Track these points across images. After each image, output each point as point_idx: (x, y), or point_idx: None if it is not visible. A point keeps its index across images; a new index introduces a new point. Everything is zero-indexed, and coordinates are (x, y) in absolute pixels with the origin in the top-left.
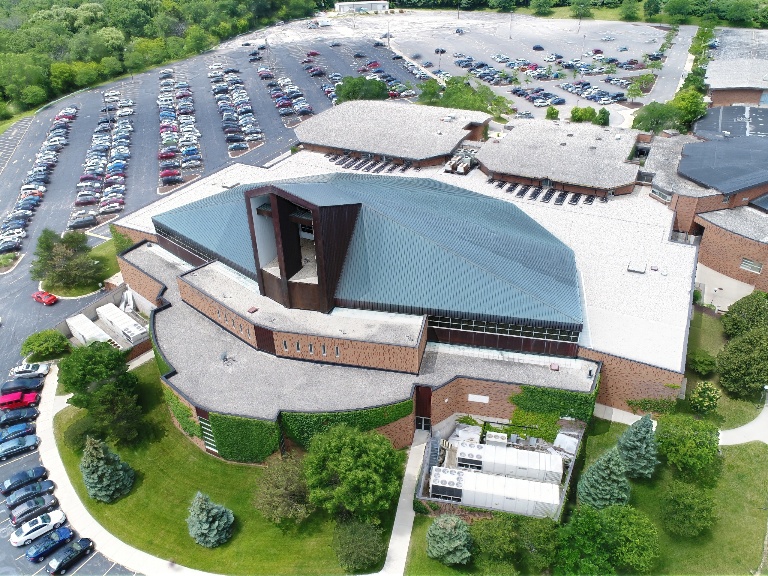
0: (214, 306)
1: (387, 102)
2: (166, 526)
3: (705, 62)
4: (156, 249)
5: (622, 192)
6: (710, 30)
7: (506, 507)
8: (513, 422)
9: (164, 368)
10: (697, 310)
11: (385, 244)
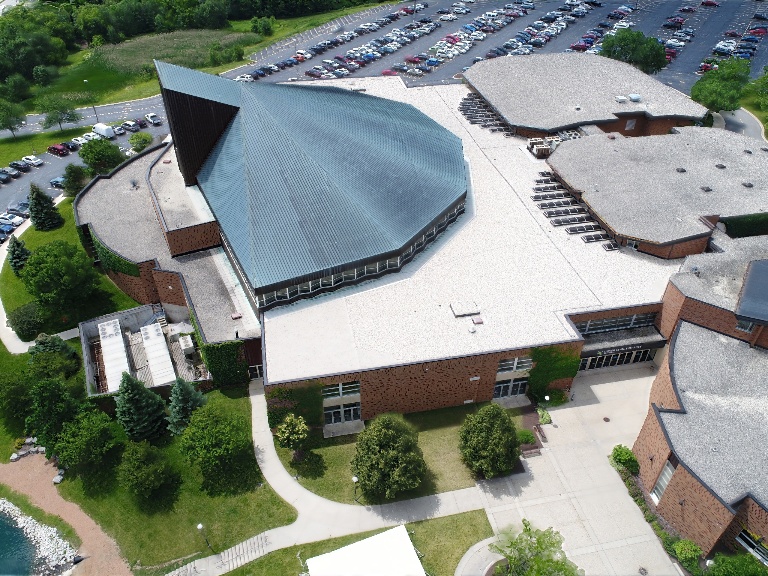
0: None
1: (625, 66)
2: None
3: None
4: None
5: (651, 251)
6: None
7: None
8: None
9: None
10: (522, 409)
11: (230, 148)
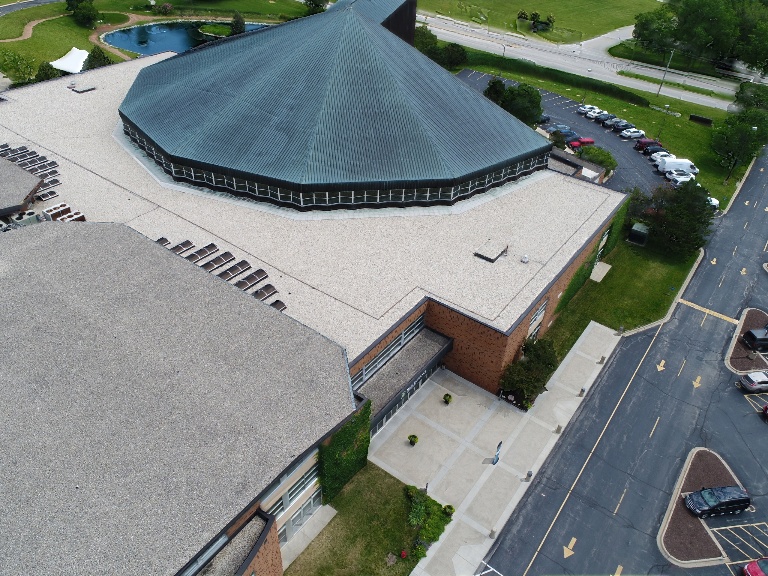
0: None
1: None
2: None
3: None
4: None
5: None
6: None
7: None
8: None
9: None
10: None
11: None
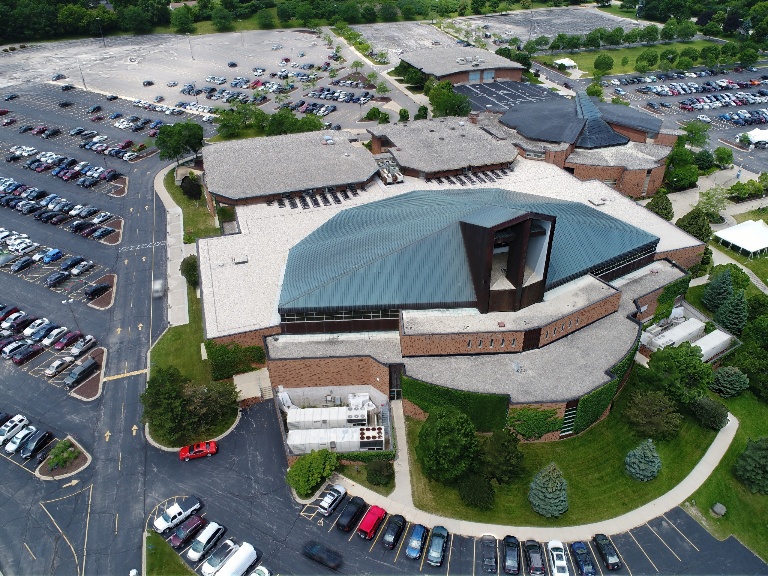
0: (465, 339)
1: (233, 142)
2: (616, 490)
3: (384, 56)
4: (288, 338)
5: None
6: (351, 30)
7: (710, 355)
8: (655, 315)
9: (490, 401)
10: None
11: None
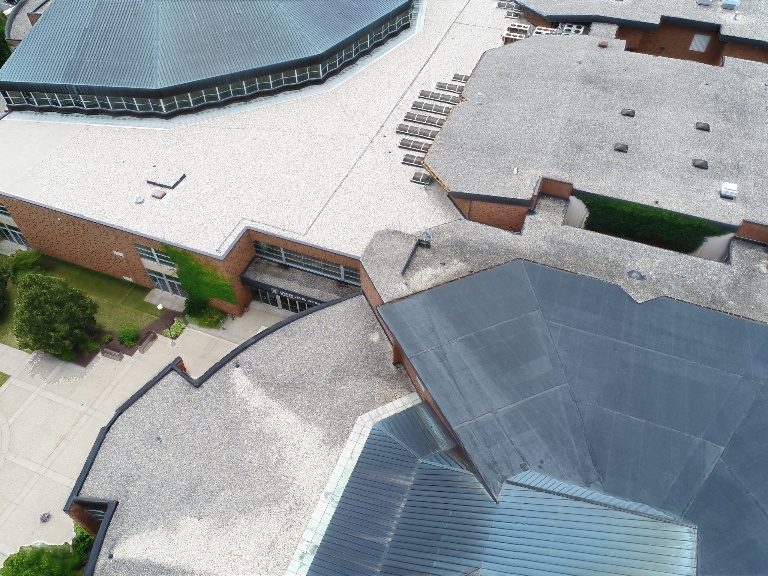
0: None
1: None
2: None
3: None
4: None
5: (457, 201)
6: None
7: None
8: None
9: None
10: (167, 311)
11: None
